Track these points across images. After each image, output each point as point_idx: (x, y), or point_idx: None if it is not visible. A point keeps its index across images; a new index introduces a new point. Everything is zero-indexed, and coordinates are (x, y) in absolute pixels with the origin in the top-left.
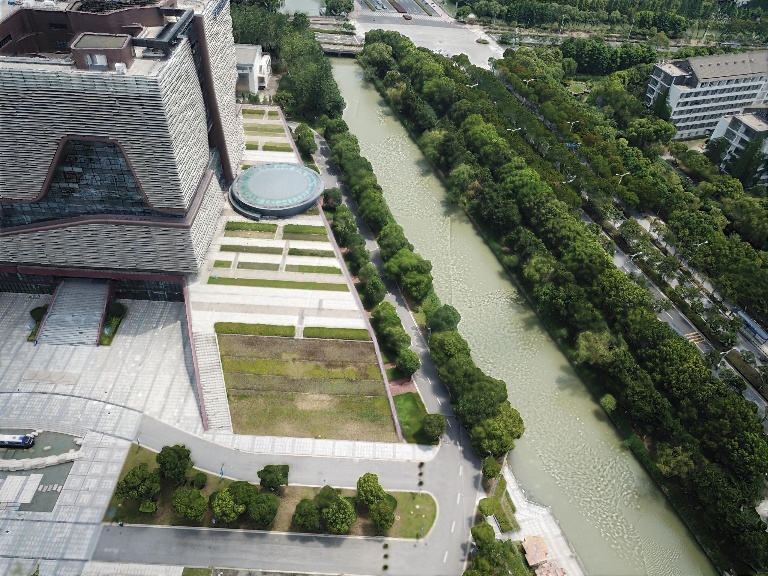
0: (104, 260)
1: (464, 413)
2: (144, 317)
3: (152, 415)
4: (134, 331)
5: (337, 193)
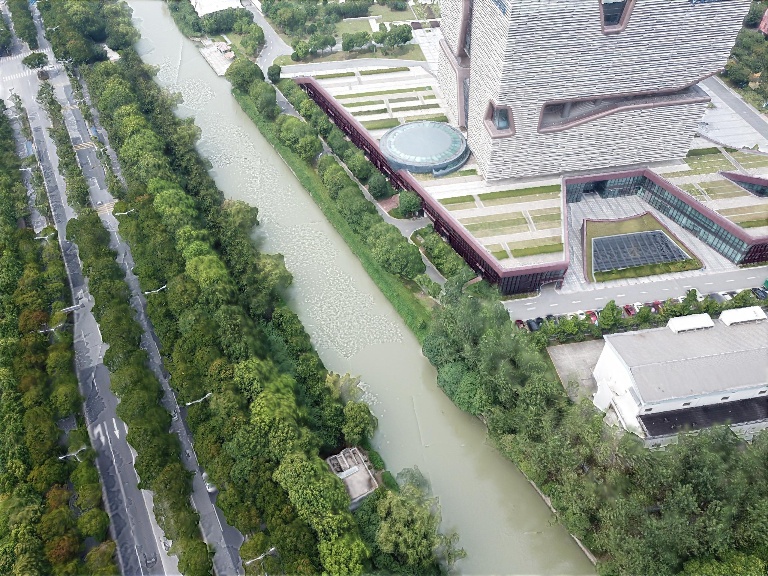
0: None
1: None
2: None
3: None
4: None
5: None
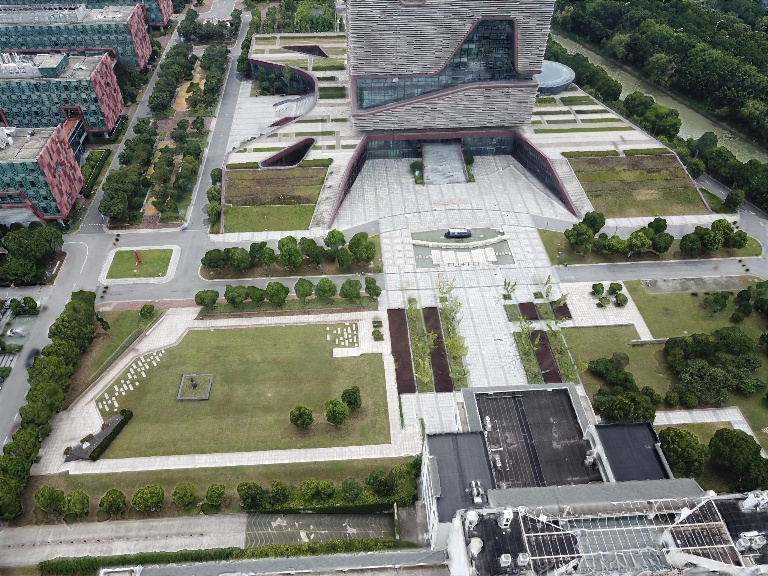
0: (465, 121)
1: (758, 186)
2: (485, 165)
3: (537, 214)
4: (485, 173)
5: (574, 79)
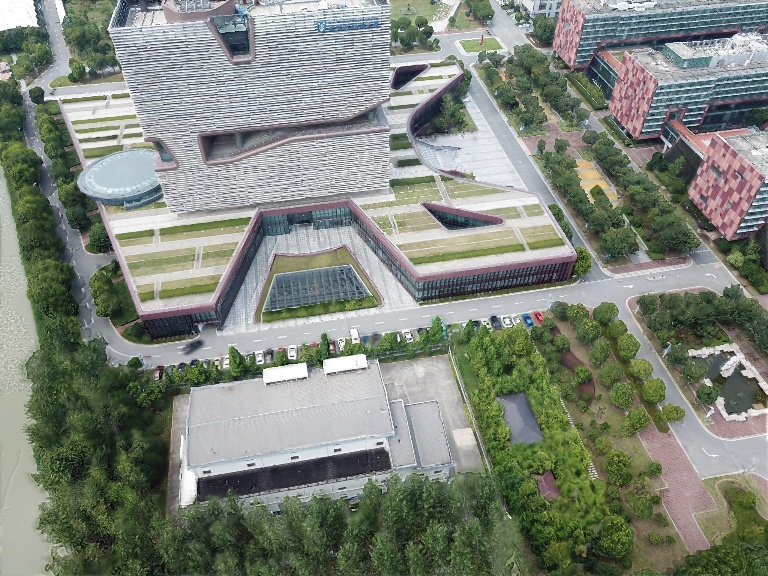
0: None
1: None
2: None
3: None
4: None
5: None
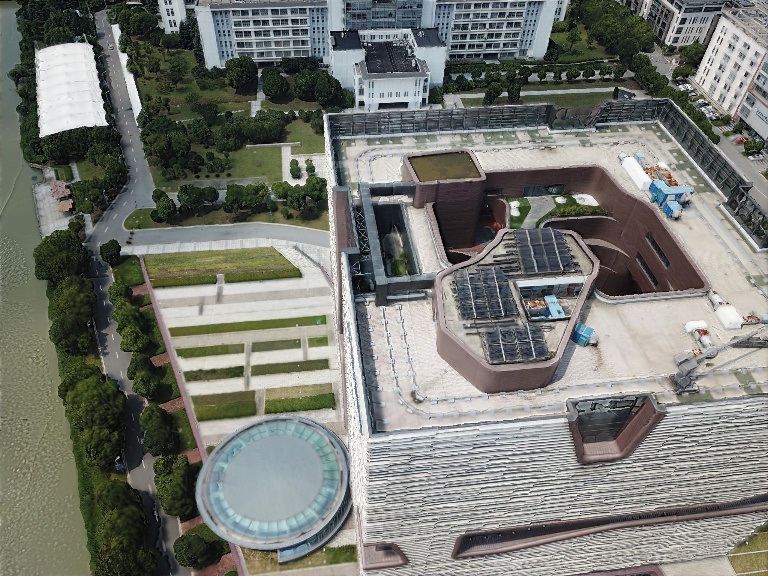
0: None
1: None
2: None
3: None
4: None
5: (181, 538)
